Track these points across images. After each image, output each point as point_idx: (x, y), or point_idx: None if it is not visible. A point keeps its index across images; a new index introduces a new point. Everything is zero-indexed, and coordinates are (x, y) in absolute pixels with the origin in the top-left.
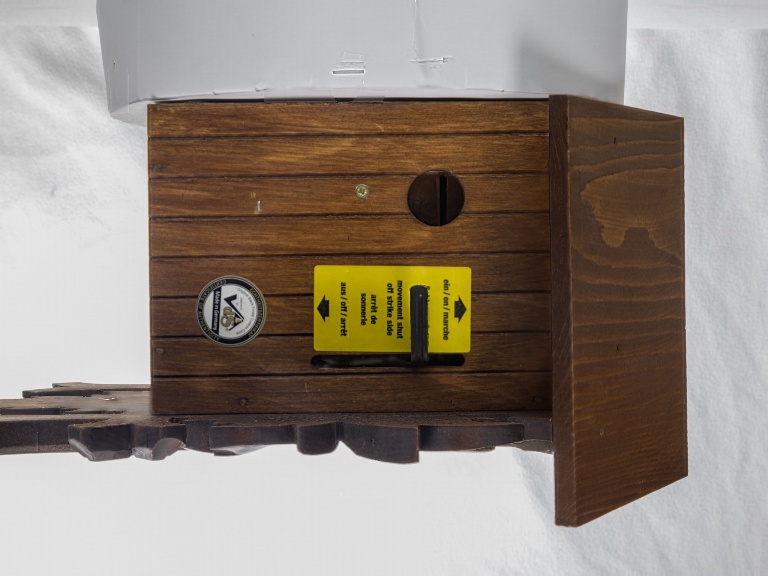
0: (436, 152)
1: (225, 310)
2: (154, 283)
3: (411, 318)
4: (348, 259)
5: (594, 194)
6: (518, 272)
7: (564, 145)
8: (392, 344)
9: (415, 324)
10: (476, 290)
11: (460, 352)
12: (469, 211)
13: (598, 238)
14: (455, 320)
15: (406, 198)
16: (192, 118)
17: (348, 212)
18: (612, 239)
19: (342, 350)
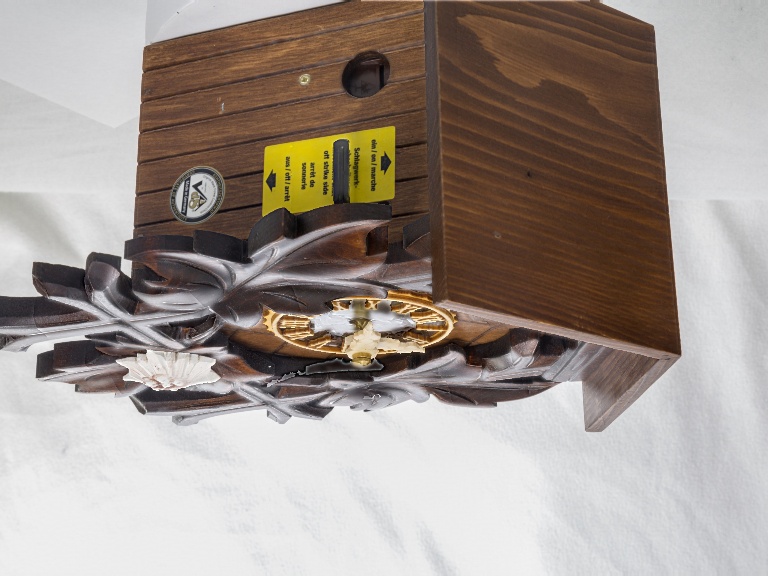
0: (366, 37)
1: (193, 195)
2: (140, 182)
3: None
4: (292, 137)
5: (482, 27)
6: None
7: None
8: (327, 202)
9: (337, 171)
10: (400, 144)
11: (386, 200)
12: (394, 80)
13: (489, 66)
14: (381, 173)
15: (341, 79)
16: (176, 50)
17: (293, 99)
18: (516, 77)
19: None
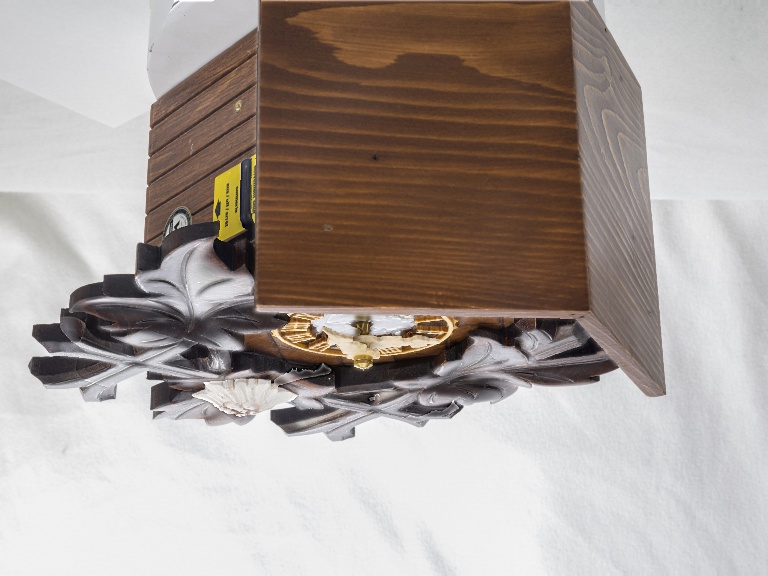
0: None
1: None
2: (146, 232)
3: None
4: (231, 164)
5: (319, 21)
6: None
7: None
8: None
9: (242, 191)
10: None
11: None
12: None
13: (326, 58)
14: None
15: None
16: None
17: (232, 127)
18: (362, 60)
19: (225, 238)
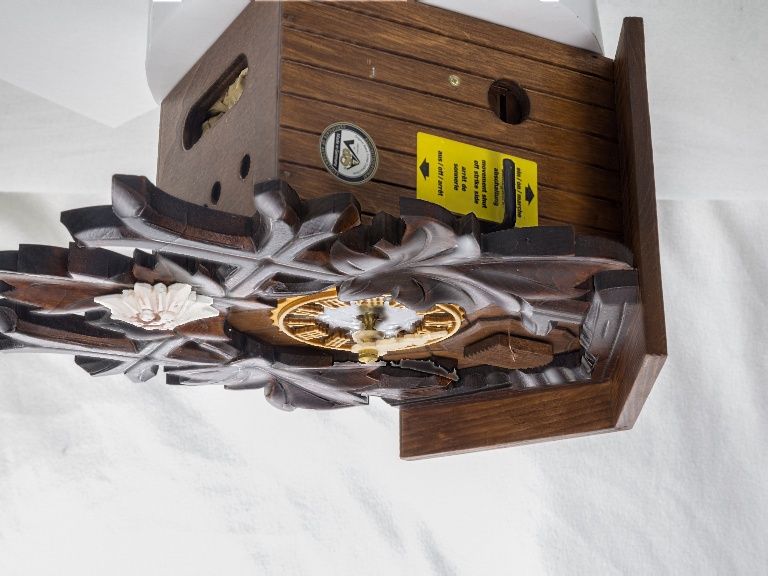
0: (509, 66)
1: (344, 151)
2: (284, 113)
3: (505, 184)
4: (444, 133)
5: None
6: (571, 175)
7: (641, 53)
8: (478, 211)
9: (508, 189)
10: (541, 182)
11: None
12: (533, 118)
13: None
14: (526, 202)
15: (487, 96)
16: None
17: (443, 95)
18: None
19: None
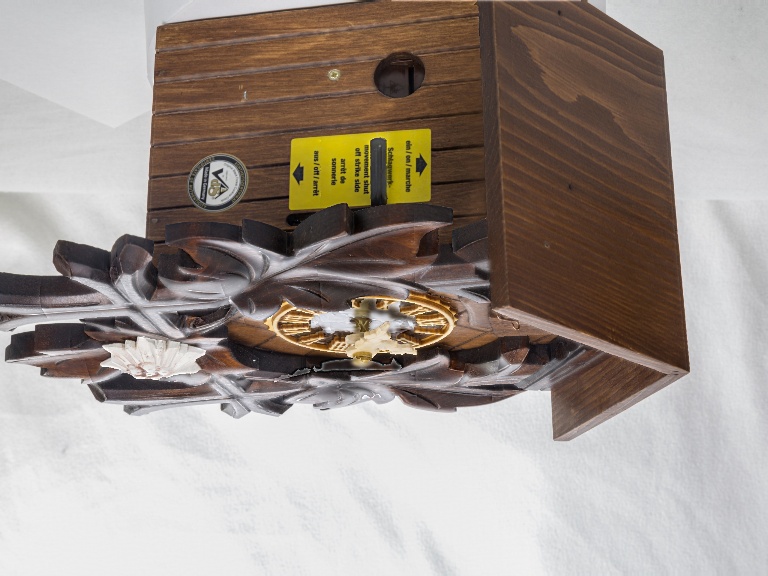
0: (399, 38)
1: (212, 182)
2: (153, 165)
3: (371, 165)
4: (321, 131)
5: (530, 39)
6: (474, 129)
7: None
8: (359, 199)
9: (374, 170)
10: (436, 147)
11: (421, 201)
12: (429, 83)
13: (537, 77)
14: (416, 174)
15: (373, 77)
16: (193, 32)
17: (322, 93)
18: (558, 90)
19: (314, 208)
